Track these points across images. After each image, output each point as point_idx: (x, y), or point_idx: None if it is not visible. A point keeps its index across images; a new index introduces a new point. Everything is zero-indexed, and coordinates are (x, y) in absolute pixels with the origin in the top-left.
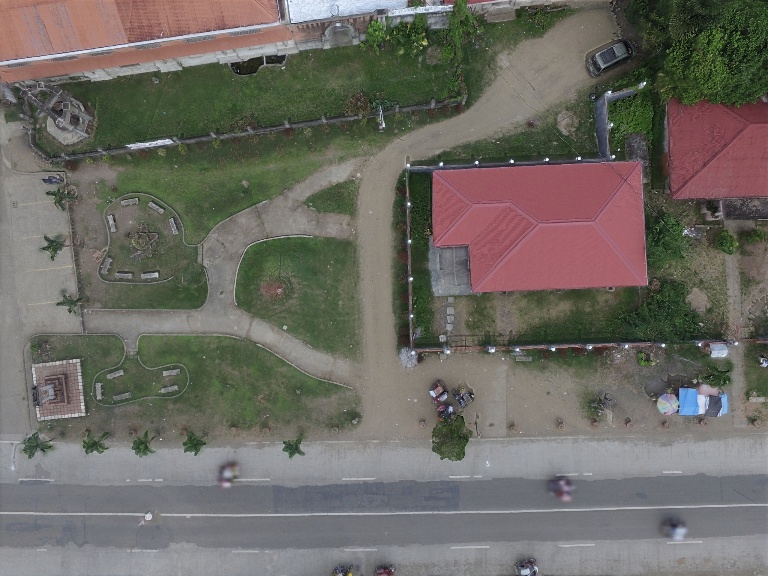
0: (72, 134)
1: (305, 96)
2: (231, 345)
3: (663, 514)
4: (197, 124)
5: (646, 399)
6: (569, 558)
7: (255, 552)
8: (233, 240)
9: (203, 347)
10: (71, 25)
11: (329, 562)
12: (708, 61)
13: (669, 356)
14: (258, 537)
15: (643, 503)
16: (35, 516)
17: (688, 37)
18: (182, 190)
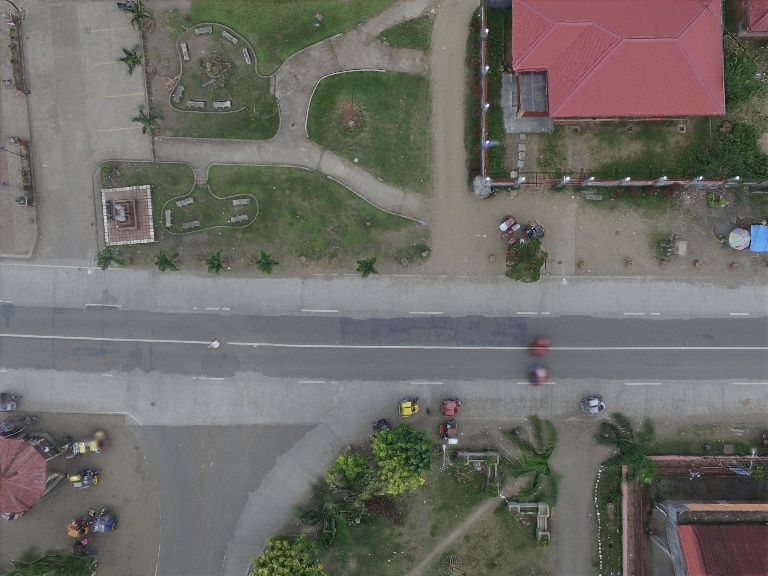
0: None
1: None
2: (302, 176)
3: (729, 355)
4: None
5: (714, 241)
6: (635, 397)
7: (321, 383)
8: (306, 73)
9: (273, 178)
10: None
11: (395, 395)
12: None
13: (739, 198)
14: (325, 368)
15: (710, 344)
16: (101, 341)
17: None
18: (256, 21)
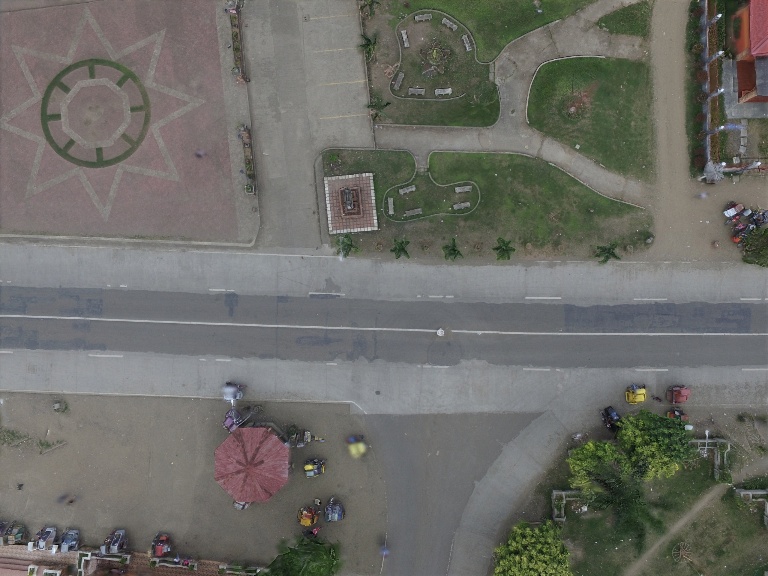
0: None
1: None
2: (523, 163)
3: None
4: None
5: None
6: None
7: (546, 370)
8: (525, 59)
9: (495, 165)
10: None
11: (620, 382)
12: None
13: None
14: (549, 355)
15: None
16: (325, 330)
17: None
18: (474, 8)
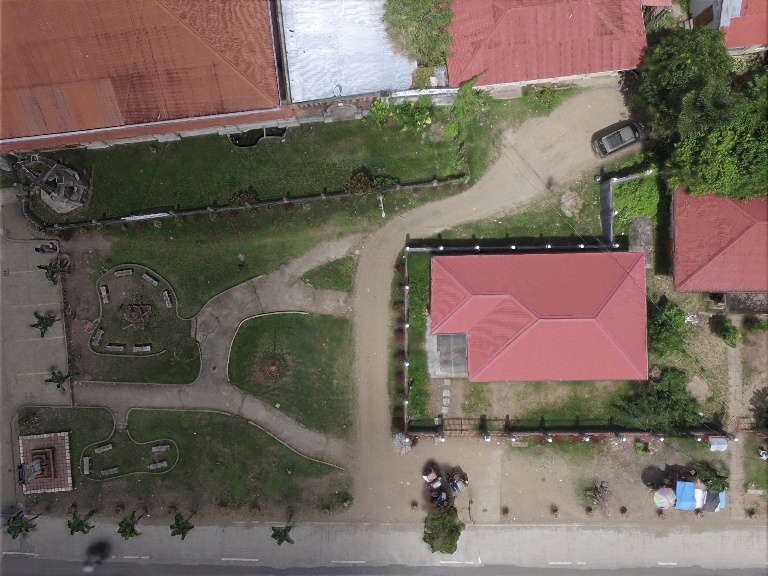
0: (66, 203)
1: (305, 170)
2: (222, 422)
3: None
4: (194, 195)
5: (643, 488)
6: None
7: None
8: (227, 314)
9: (194, 423)
10: (66, 106)
11: None
12: (716, 162)
13: (667, 445)
14: None
15: None
16: None
17: (697, 136)
18: (177, 262)
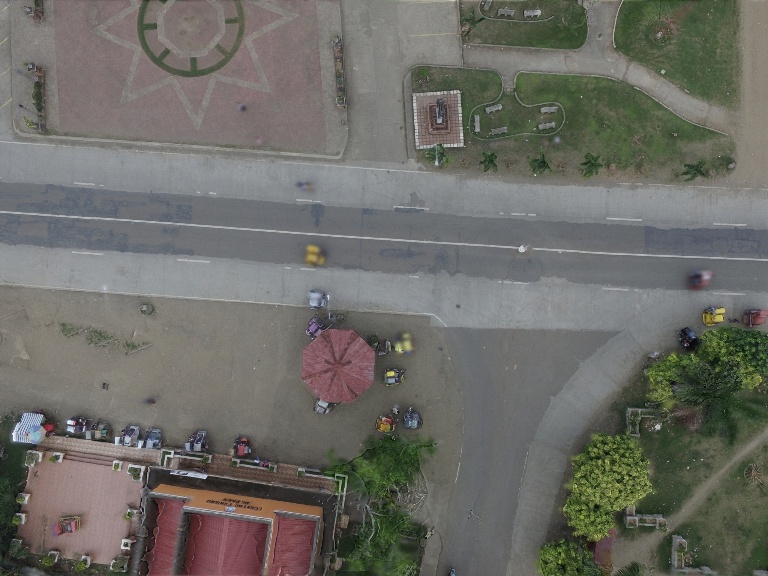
0: None
1: None
2: (608, 86)
3: None
4: None
5: None
6: None
7: (625, 290)
8: None
9: (580, 87)
10: None
11: (697, 304)
12: None
13: None
14: (629, 275)
15: None
16: (409, 243)
17: None
18: None
